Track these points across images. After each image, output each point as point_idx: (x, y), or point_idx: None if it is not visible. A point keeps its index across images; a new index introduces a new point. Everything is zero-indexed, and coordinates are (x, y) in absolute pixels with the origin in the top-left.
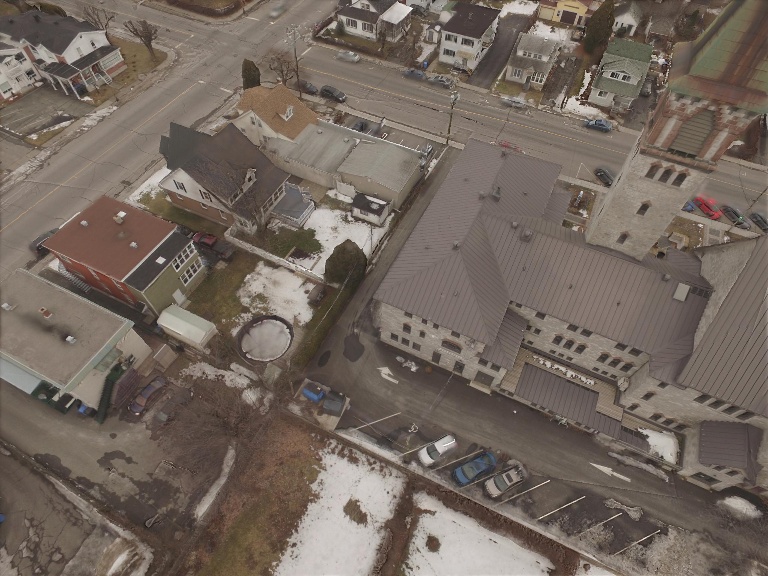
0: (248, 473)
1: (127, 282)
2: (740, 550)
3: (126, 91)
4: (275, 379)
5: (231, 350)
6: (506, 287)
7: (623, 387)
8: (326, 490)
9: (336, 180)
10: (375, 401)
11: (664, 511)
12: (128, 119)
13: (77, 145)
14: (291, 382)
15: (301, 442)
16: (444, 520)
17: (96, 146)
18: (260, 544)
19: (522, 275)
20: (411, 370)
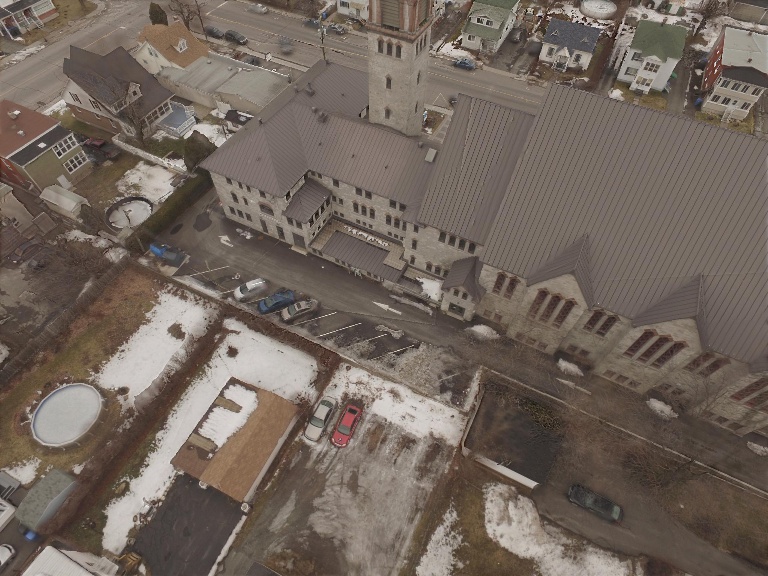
0: (97, 304)
1: (11, 159)
2: (472, 359)
3: (55, 34)
4: (127, 237)
5: (100, 220)
6: (306, 159)
7: (403, 243)
8: (157, 317)
9: (215, 100)
10: (210, 258)
11: (421, 333)
12: (53, 56)
13: (4, 75)
14: (138, 238)
15: (145, 285)
16: (245, 337)
17: (21, 75)
18: (96, 349)
19: (318, 149)
20: (246, 238)
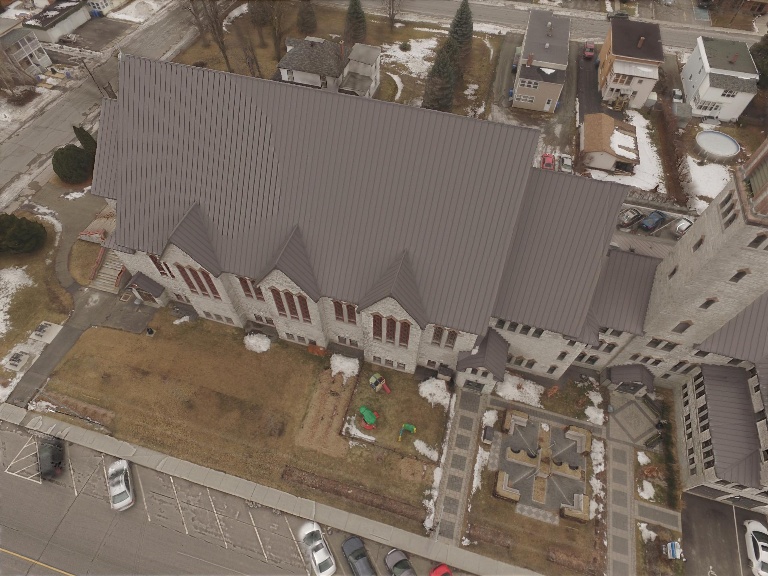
0: None
1: None
2: None
3: None
4: None
5: None
6: None
7: None
8: None
9: None
10: None
11: None
12: None
13: None
14: None
15: None
16: None
17: None
18: None
19: None
20: None
